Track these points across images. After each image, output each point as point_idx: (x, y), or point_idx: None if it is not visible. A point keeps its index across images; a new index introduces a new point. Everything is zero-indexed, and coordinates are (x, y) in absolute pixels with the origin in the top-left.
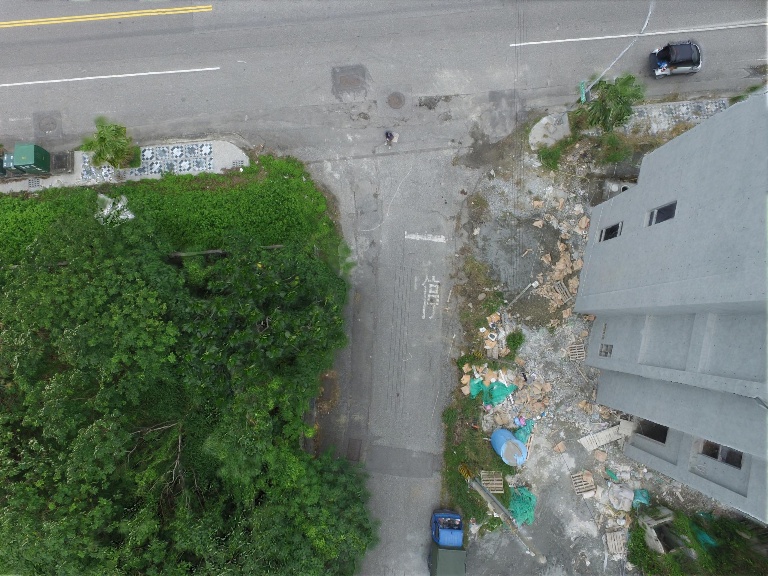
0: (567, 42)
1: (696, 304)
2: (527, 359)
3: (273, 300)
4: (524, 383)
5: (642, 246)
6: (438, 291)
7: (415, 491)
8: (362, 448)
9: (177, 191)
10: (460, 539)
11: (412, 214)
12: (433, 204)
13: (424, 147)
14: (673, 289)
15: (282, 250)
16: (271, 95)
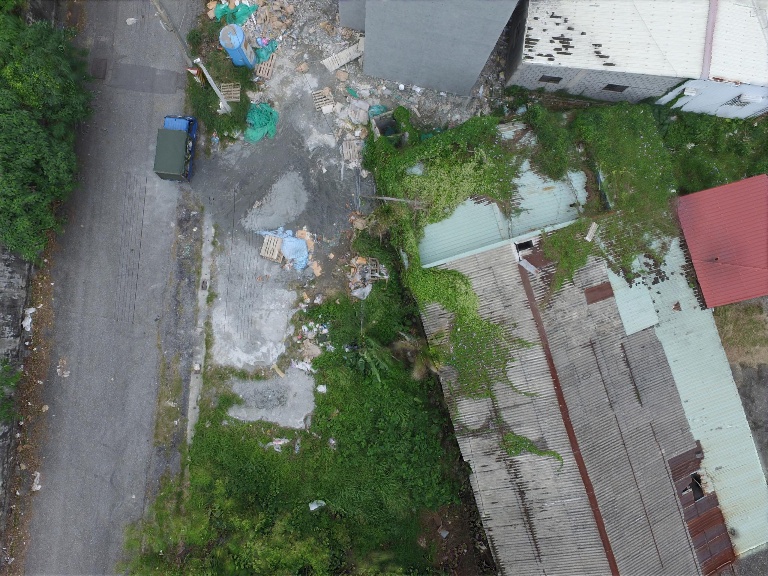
0: None
1: None
2: None
3: None
4: (264, 1)
5: None
6: None
7: (158, 105)
8: (108, 67)
9: None
10: (184, 125)
11: None
12: None
13: None
14: None
15: None
16: None
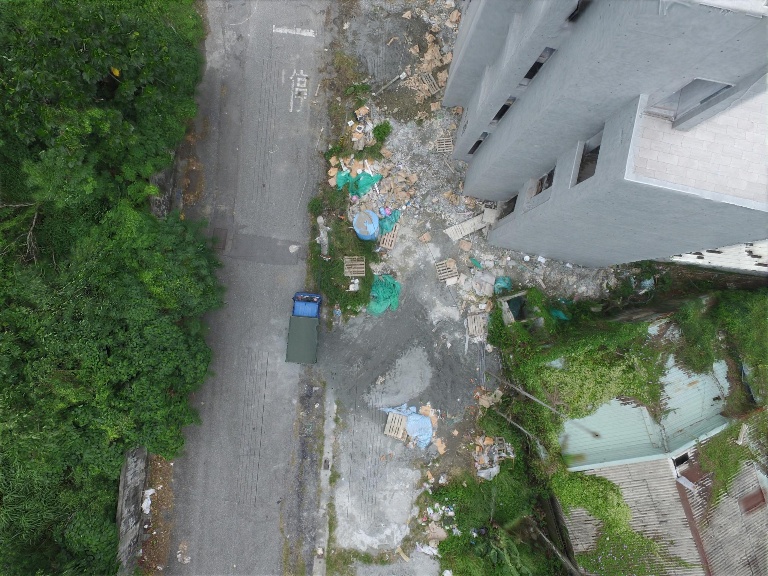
0: None
1: None
2: (394, 151)
3: None
4: (389, 171)
5: None
6: (306, 85)
7: (280, 277)
8: (228, 237)
9: None
10: (314, 310)
11: (281, 8)
12: None
13: None
14: None
15: None
16: None
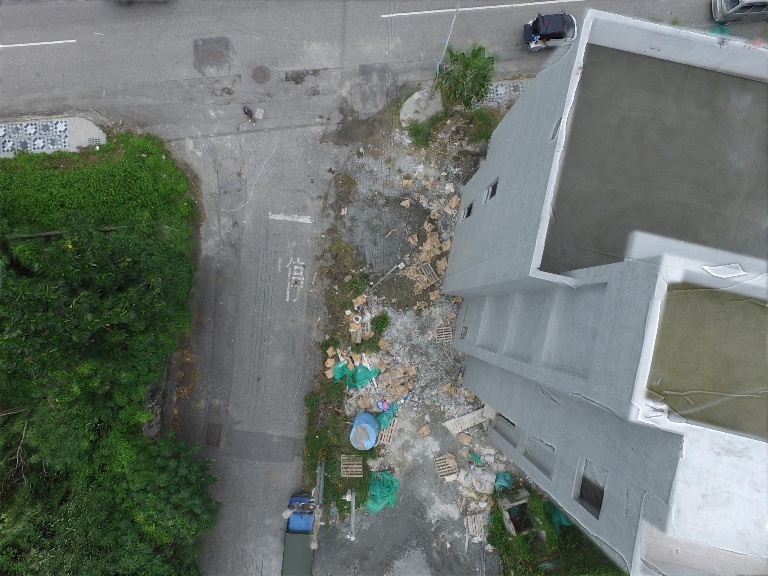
0: (441, 13)
1: (492, 284)
2: (392, 342)
3: (94, 282)
4: (387, 366)
5: (478, 225)
6: (303, 273)
7: (275, 475)
8: (222, 433)
9: (28, 170)
10: (310, 523)
11: (277, 194)
12: (299, 183)
13: (290, 124)
14: (483, 269)
15: (118, 231)
16: (130, 69)
